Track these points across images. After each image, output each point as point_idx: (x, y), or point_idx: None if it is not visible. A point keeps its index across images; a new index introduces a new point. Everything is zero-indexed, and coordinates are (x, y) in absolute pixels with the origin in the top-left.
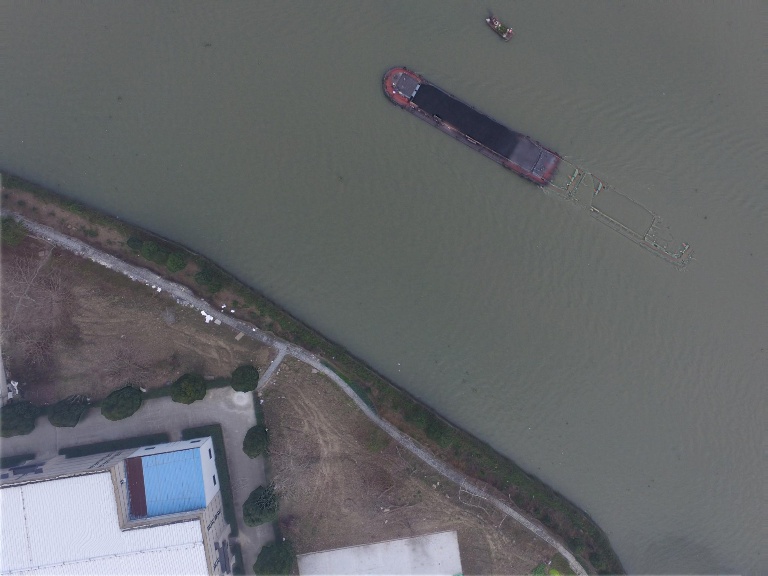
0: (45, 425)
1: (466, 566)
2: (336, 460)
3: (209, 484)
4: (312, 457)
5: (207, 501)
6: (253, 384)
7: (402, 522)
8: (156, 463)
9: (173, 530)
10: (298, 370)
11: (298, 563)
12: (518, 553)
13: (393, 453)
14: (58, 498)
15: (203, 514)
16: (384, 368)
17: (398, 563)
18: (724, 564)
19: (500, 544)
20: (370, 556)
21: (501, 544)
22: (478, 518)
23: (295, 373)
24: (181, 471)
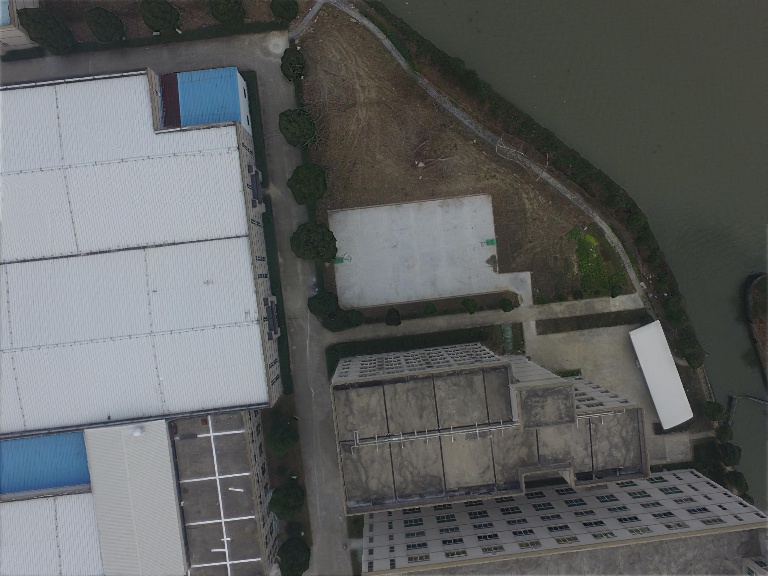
0: (78, 64)
1: (500, 231)
2: (372, 105)
3: (244, 114)
4: (348, 105)
5: (242, 121)
6: (293, 8)
7: (437, 178)
8: (192, 79)
9: (208, 135)
10: (337, 16)
11: (329, 219)
12: (554, 214)
13: (430, 108)
14: (91, 113)
15: (238, 124)
16: (422, 33)
17: (430, 224)
18: (762, 254)
19: (536, 203)
20: (402, 216)
21: (537, 203)
22: (514, 176)
23: (334, 19)
24: (217, 88)
